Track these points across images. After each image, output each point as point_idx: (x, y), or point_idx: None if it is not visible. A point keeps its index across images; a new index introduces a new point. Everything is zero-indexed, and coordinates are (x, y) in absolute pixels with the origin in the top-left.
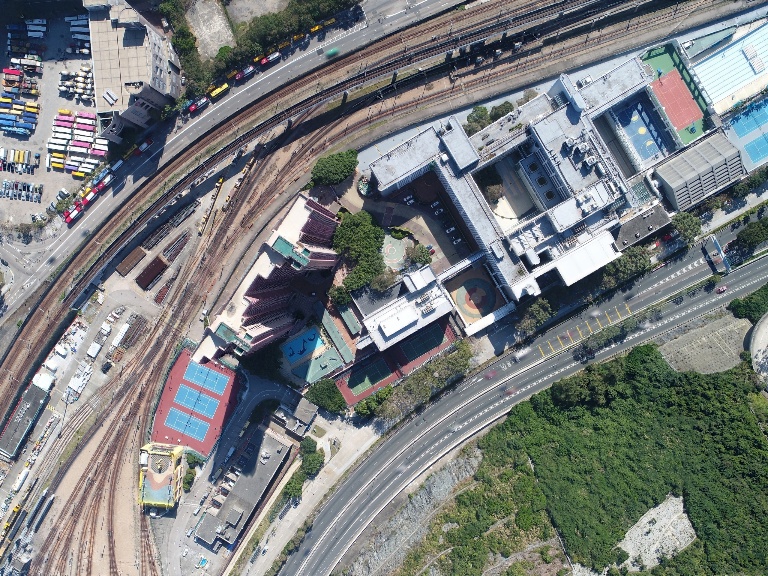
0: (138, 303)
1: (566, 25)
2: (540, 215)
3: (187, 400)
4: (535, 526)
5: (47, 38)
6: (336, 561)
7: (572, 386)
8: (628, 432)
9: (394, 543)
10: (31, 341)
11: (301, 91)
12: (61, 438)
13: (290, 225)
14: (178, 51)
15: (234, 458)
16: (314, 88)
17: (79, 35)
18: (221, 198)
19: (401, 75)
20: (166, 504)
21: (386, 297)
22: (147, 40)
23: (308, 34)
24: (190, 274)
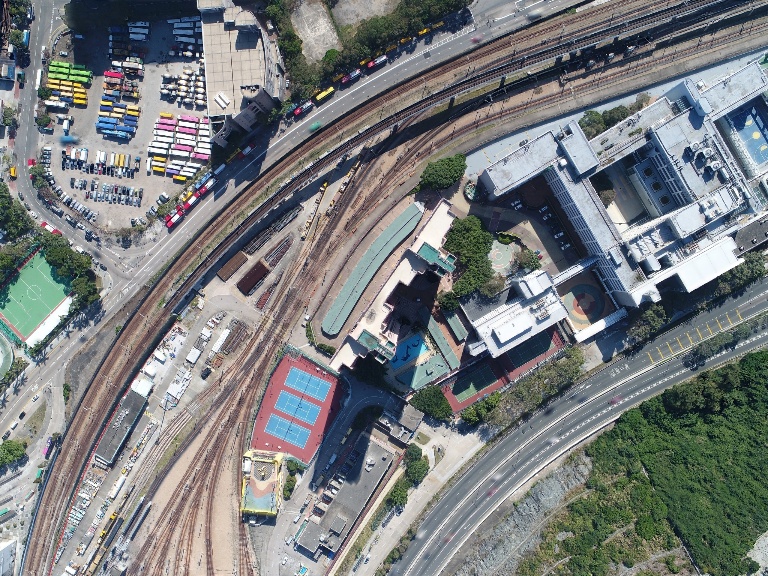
0: (239, 308)
1: (679, 29)
2: (660, 220)
3: (288, 406)
4: (657, 535)
5: (149, 41)
6: (439, 570)
7: (688, 393)
8: (746, 440)
9: (503, 552)
10: (129, 347)
11: (407, 95)
12: (159, 445)
13: (432, 231)
14: (282, 54)
15: (335, 465)
16: (420, 92)
17: (182, 38)
18: (325, 202)
19: (509, 79)
20: (269, 512)
21: (494, 303)
22: (260, 43)
23: (415, 37)
24: (292, 279)
